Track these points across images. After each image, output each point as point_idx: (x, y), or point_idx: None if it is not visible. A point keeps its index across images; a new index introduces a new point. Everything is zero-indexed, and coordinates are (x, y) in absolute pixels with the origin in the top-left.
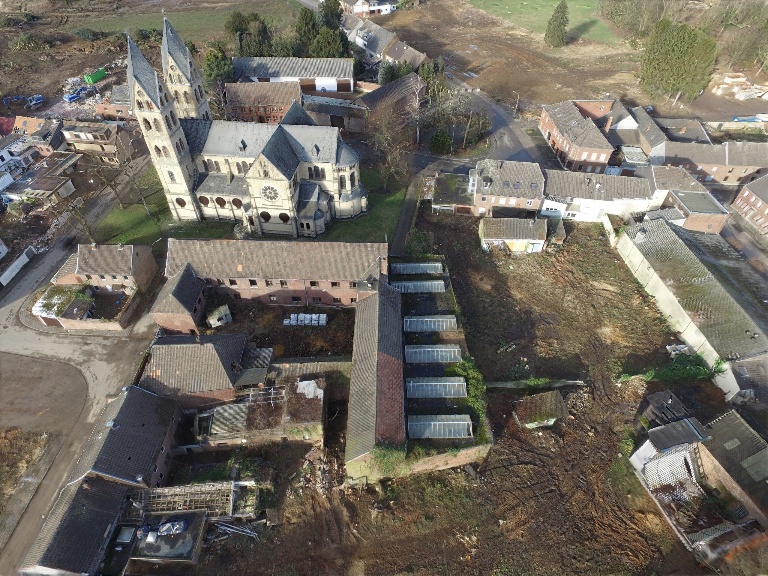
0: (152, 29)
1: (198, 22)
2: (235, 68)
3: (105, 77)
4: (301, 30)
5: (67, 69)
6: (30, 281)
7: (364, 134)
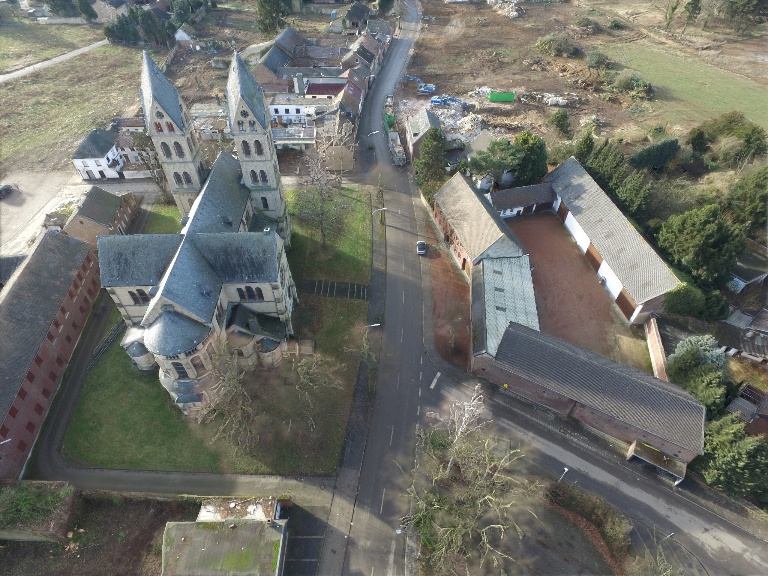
0: (646, 83)
1: (736, 104)
2: (557, 169)
3: (509, 102)
4: (741, 189)
5: (512, 79)
6: (129, 187)
7: (465, 372)
